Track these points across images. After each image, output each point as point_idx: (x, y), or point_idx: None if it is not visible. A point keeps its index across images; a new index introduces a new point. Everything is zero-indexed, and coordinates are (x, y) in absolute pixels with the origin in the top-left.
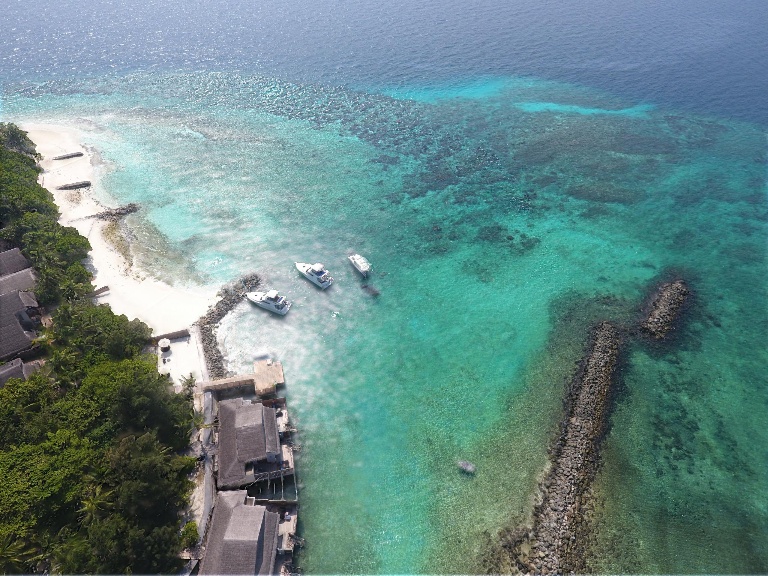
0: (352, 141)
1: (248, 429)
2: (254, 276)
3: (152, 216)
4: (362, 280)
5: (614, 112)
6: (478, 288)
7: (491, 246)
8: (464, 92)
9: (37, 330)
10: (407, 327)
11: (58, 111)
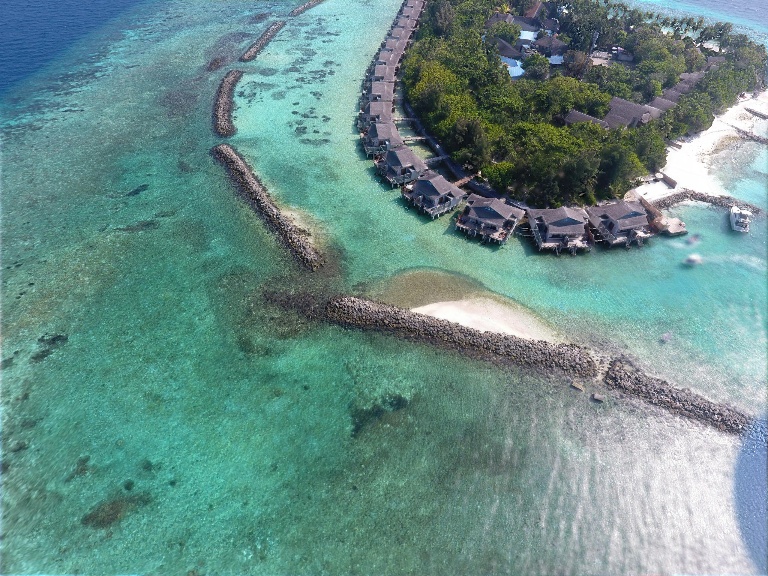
0: None
1: (626, 207)
2: (758, 209)
3: (767, 152)
4: None
5: None
6: None
7: None
8: None
9: None
10: None
11: None
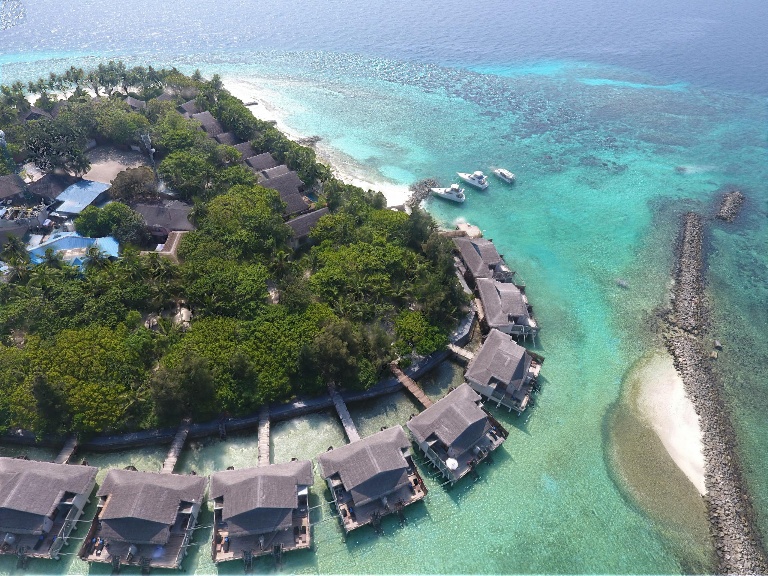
0: (459, 101)
1: (486, 246)
2: (431, 180)
3: (334, 144)
4: (507, 185)
5: (659, 87)
6: (592, 192)
7: (592, 169)
8: (533, 70)
9: None
10: (551, 212)
11: None
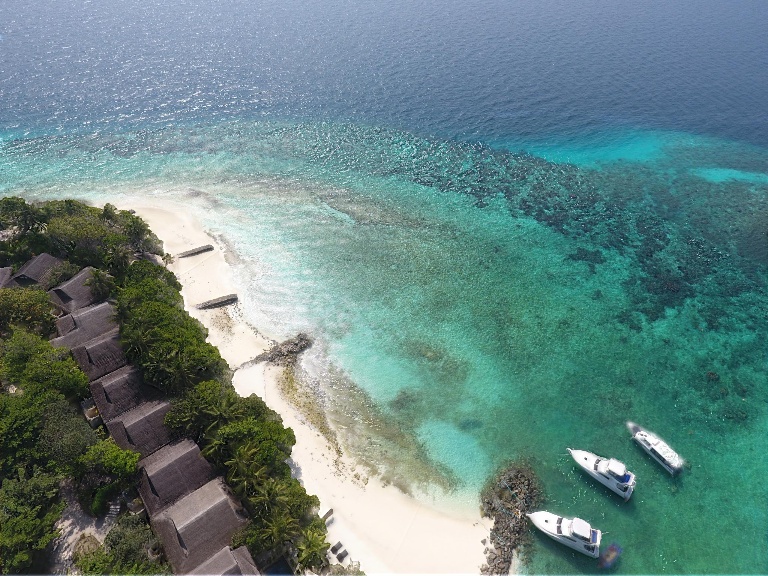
0: (531, 225)
1: None
2: (521, 475)
3: (334, 355)
4: (666, 478)
5: None
6: None
7: None
8: (622, 152)
9: None
10: None
11: (162, 178)
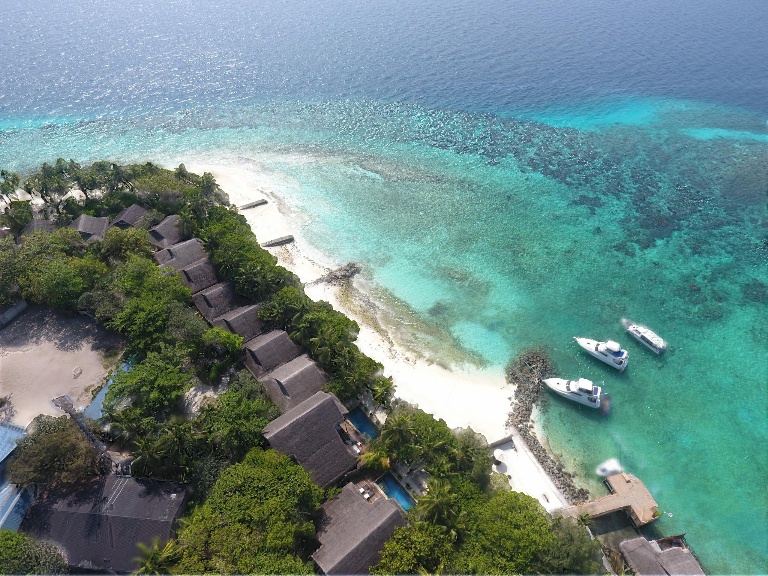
0: (538, 179)
1: None
2: (537, 356)
3: (379, 278)
4: (653, 358)
5: None
6: None
7: (767, 309)
8: (619, 117)
9: (345, 439)
10: (741, 421)
11: (214, 149)
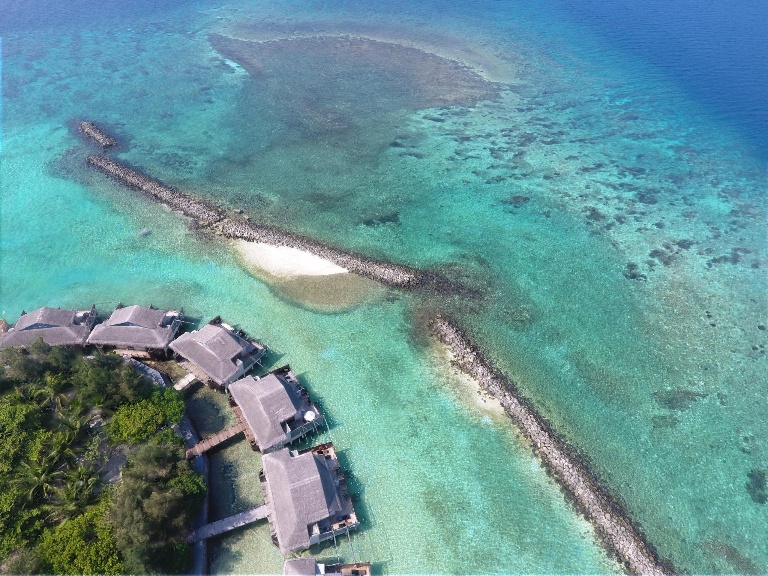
0: None
1: (44, 316)
2: None
3: None
4: None
5: None
6: None
7: None
8: None
9: None
10: (5, 248)
11: None
